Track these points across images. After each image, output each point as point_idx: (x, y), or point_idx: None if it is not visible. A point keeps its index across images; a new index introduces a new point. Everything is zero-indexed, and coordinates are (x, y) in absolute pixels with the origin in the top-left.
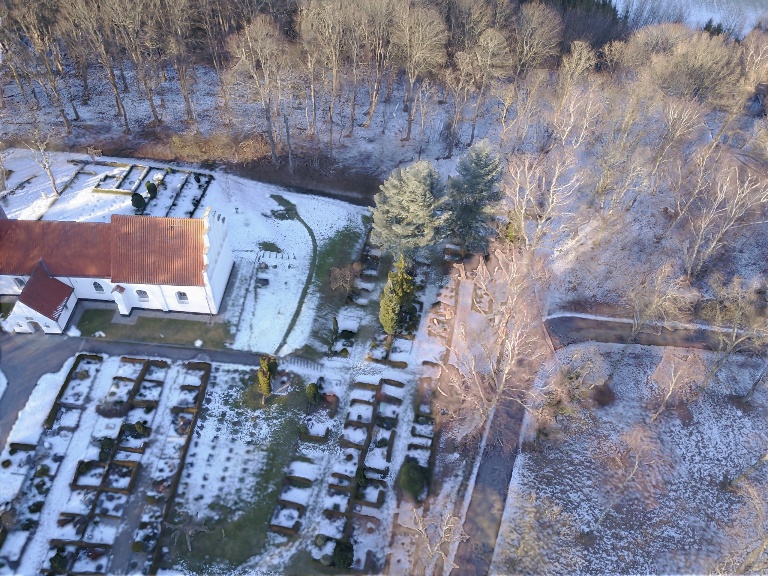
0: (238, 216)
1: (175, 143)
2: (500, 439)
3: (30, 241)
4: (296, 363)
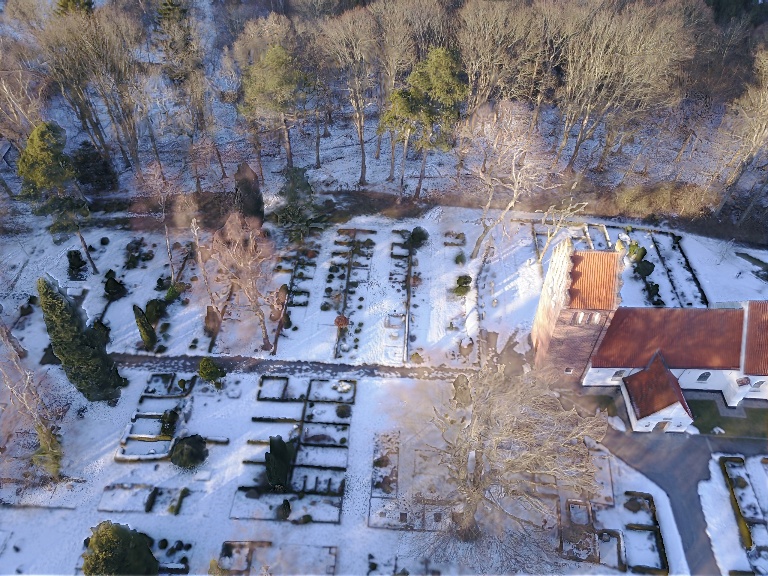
0: (741, 281)
1: (617, 198)
2: None
3: (648, 330)
4: None
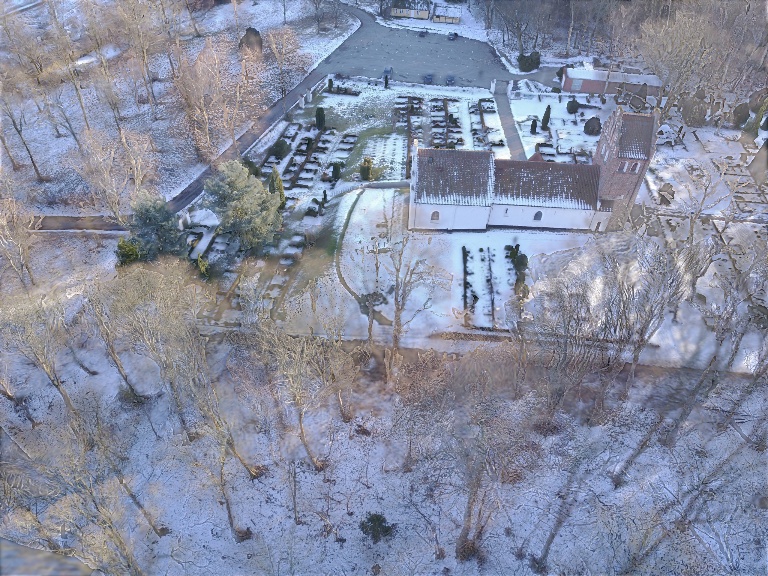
0: None
1: None
2: None
3: None
4: (349, 189)
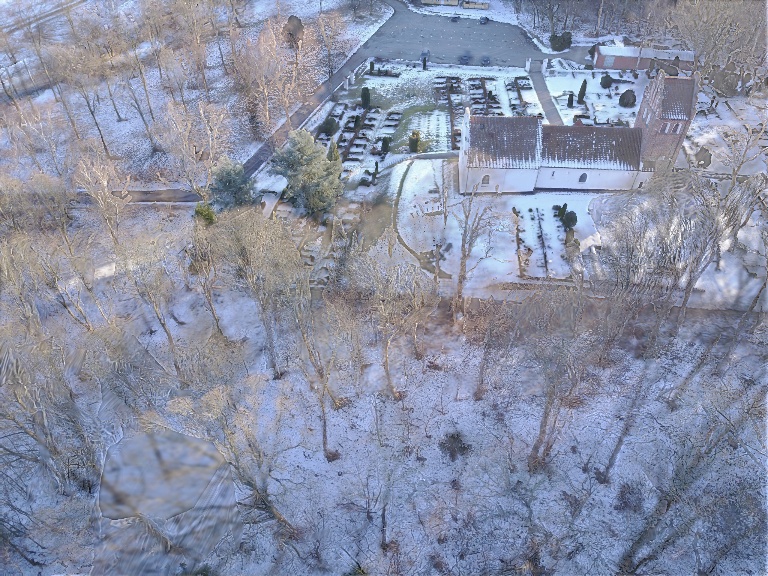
0: None
1: None
2: (276, 142)
3: None
4: (399, 161)
